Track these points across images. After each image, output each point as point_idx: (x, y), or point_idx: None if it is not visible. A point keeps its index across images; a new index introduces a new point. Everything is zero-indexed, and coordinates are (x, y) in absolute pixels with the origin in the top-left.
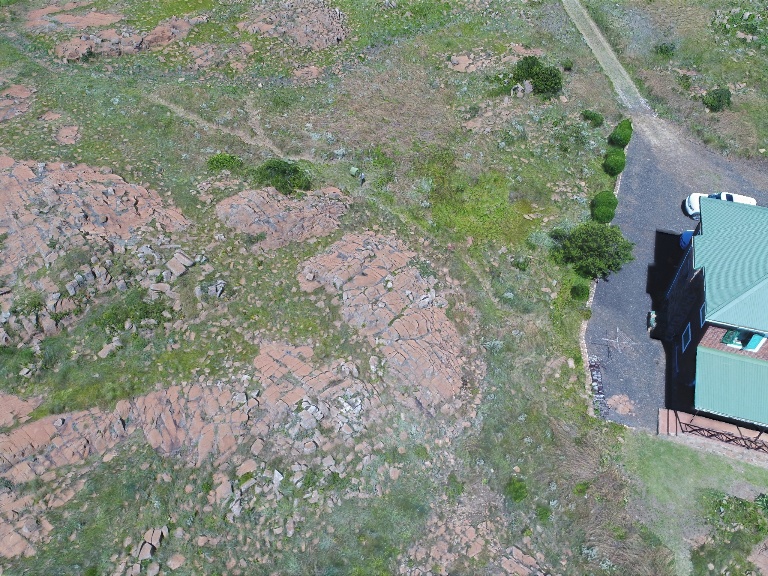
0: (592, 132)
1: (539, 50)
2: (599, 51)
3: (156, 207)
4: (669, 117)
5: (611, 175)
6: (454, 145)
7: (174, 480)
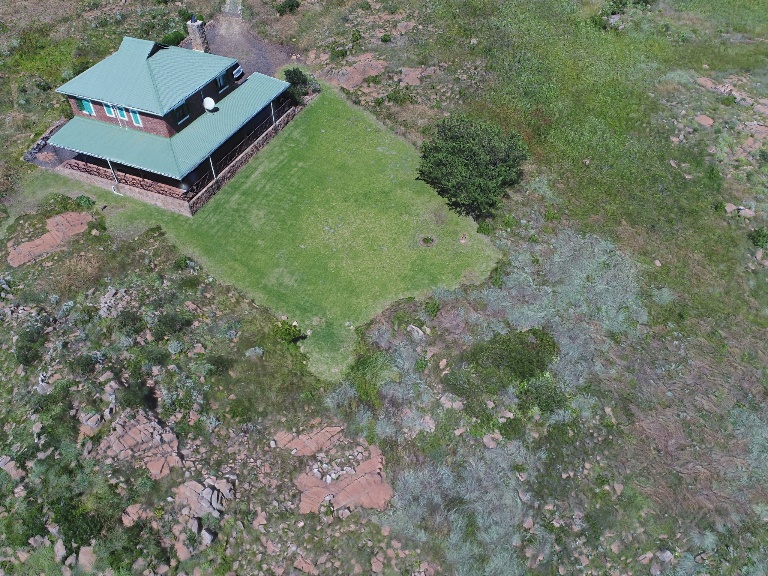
0: (182, 25)
1: None
2: None
3: None
4: (247, 18)
5: None
6: None
7: None
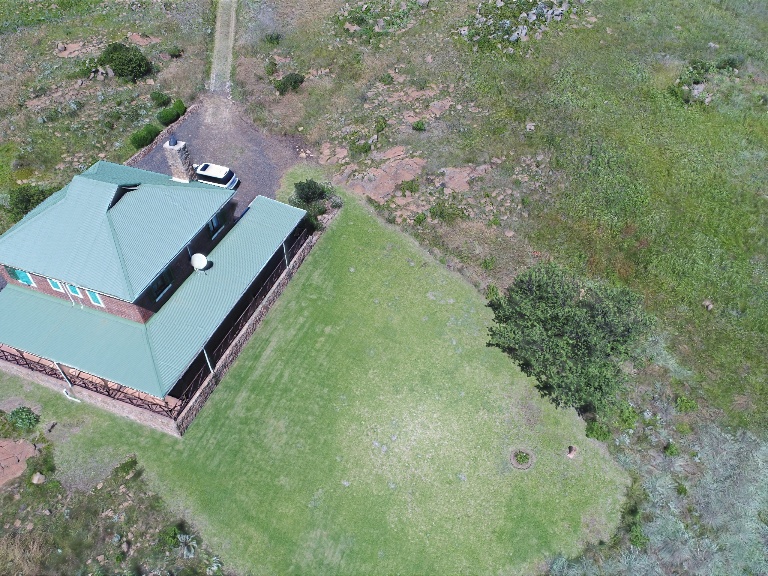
0: (155, 111)
1: (158, 39)
2: (221, 40)
3: None
4: (238, 99)
5: (136, 148)
6: None
7: None
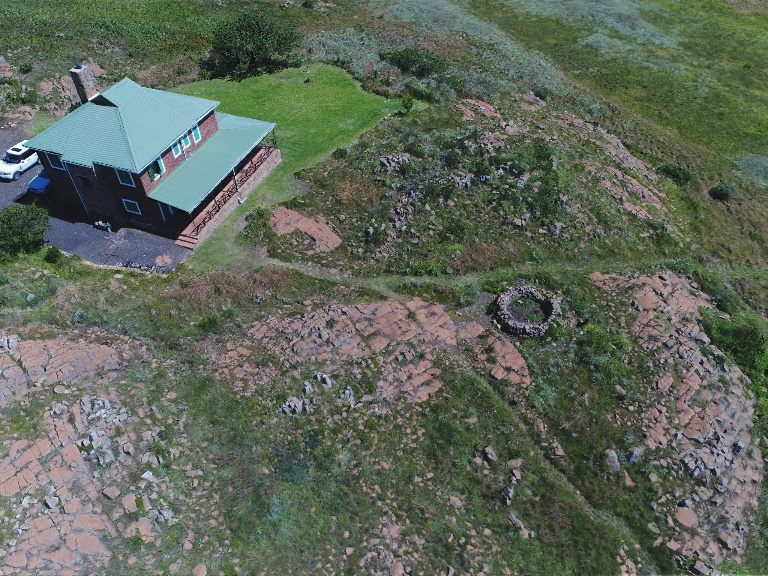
0: None
1: None
2: None
3: None
4: None
5: None
6: None
7: (118, 575)
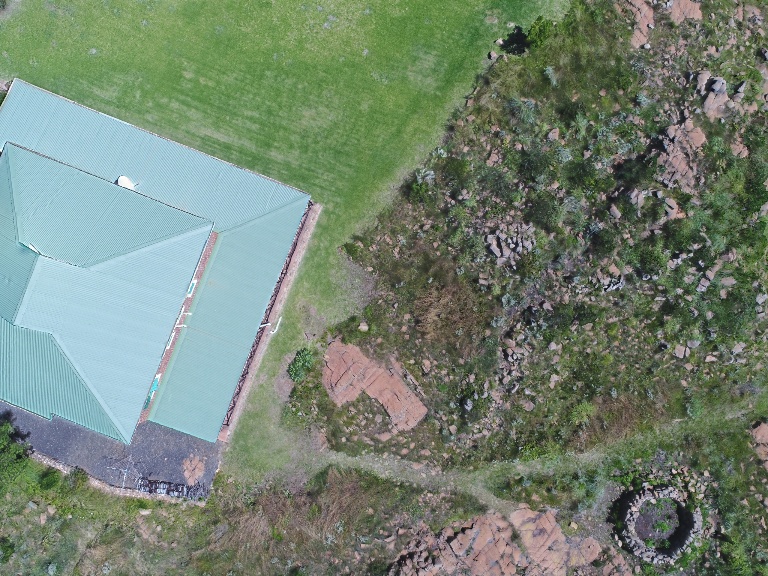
0: None
1: None
2: None
3: None
4: None
5: None
6: None
7: None
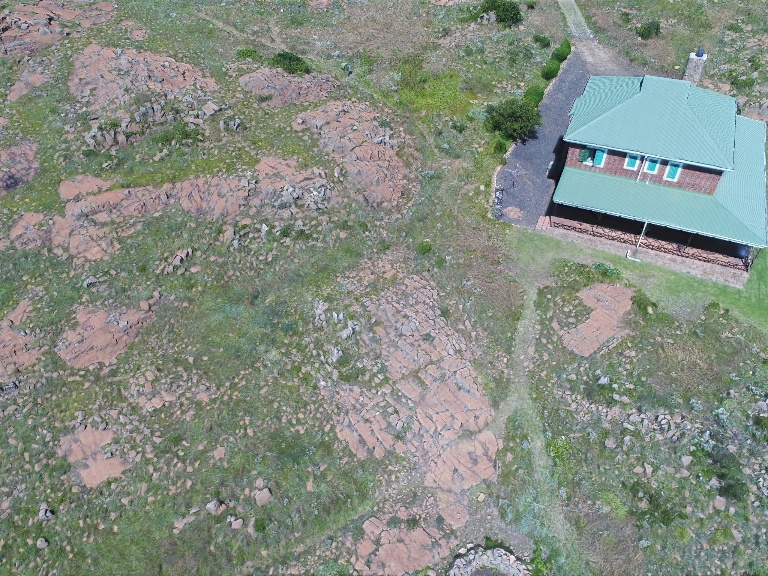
0: (540, 52)
1: None
2: None
3: (197, 77)
4: (606, 43)
5: (546, 79)
6: (425, 54)
7: (198, 226)
